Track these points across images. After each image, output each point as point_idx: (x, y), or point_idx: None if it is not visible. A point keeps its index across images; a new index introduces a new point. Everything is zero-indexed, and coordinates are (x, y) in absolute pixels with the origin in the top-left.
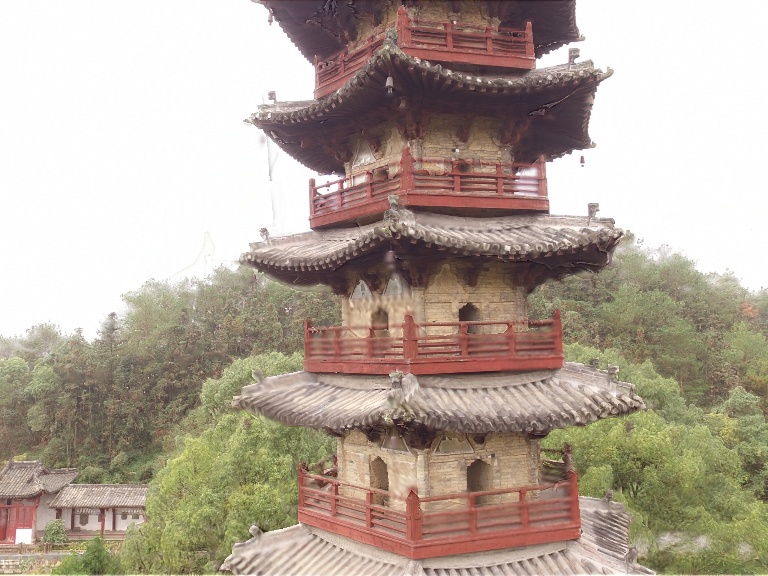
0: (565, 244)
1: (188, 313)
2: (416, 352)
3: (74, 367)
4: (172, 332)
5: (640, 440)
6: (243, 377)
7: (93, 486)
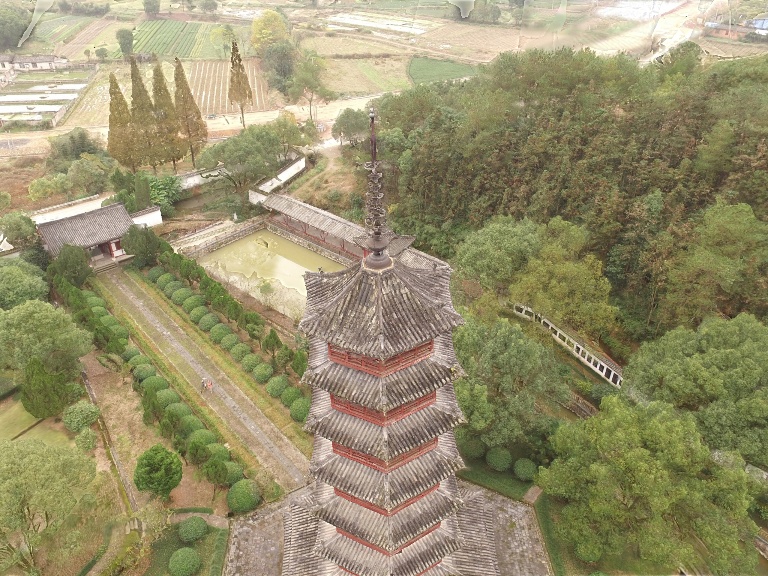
0: (369, 501)
1: (515, 109)
2: (337, 490)
3: (424, 155)
4: (491, 138)
5: (641, 468)
6: (482, 251)
7: (419, 255)
